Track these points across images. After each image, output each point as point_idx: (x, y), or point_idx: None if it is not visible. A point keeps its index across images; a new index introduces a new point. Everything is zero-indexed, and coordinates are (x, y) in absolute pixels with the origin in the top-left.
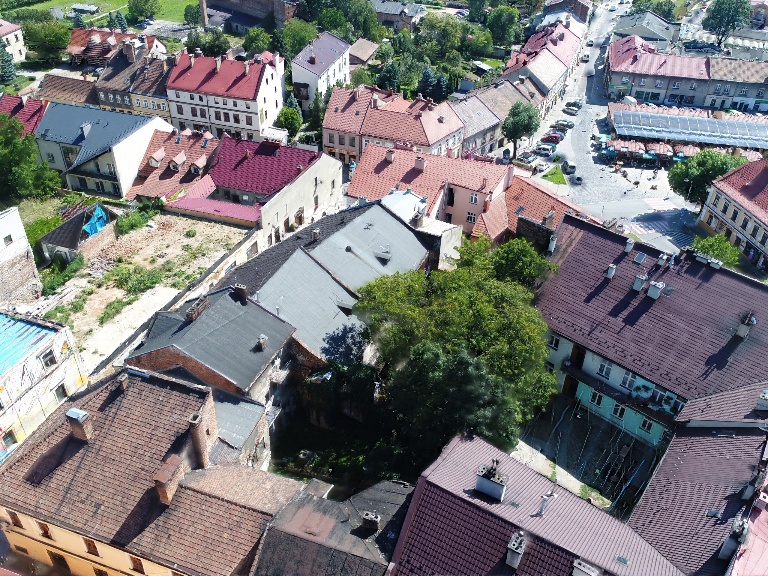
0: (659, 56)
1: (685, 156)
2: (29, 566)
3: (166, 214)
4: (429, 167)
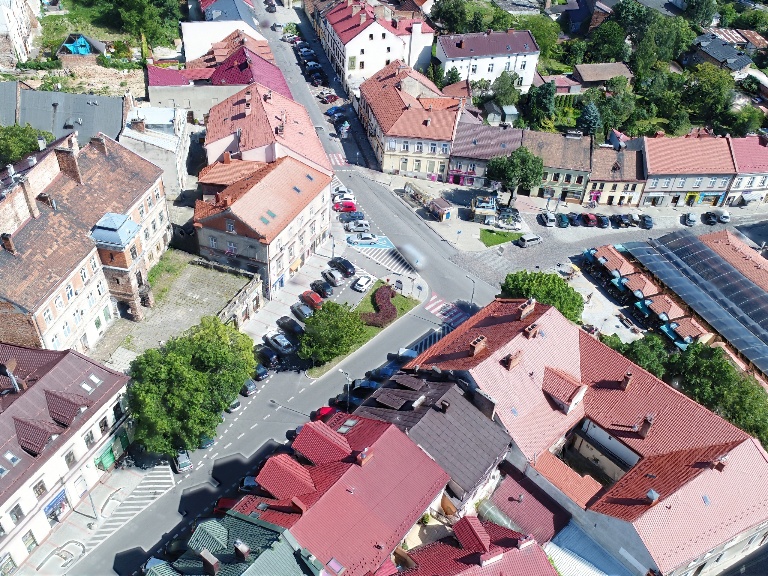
0: None
1: (649, 307)
2: None
3: (144, 71)
4: (252, 116)
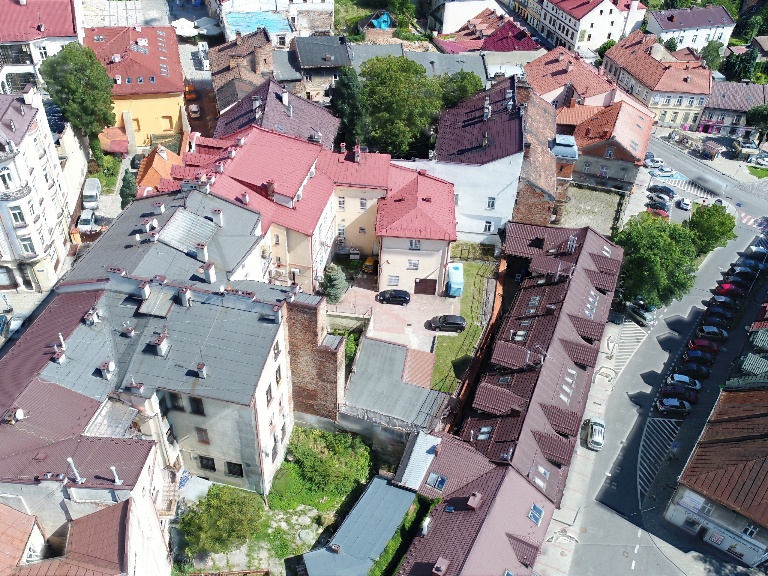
0: None
1: None
2: (211, 93)
3: (431, 43)
4: (574, 72)
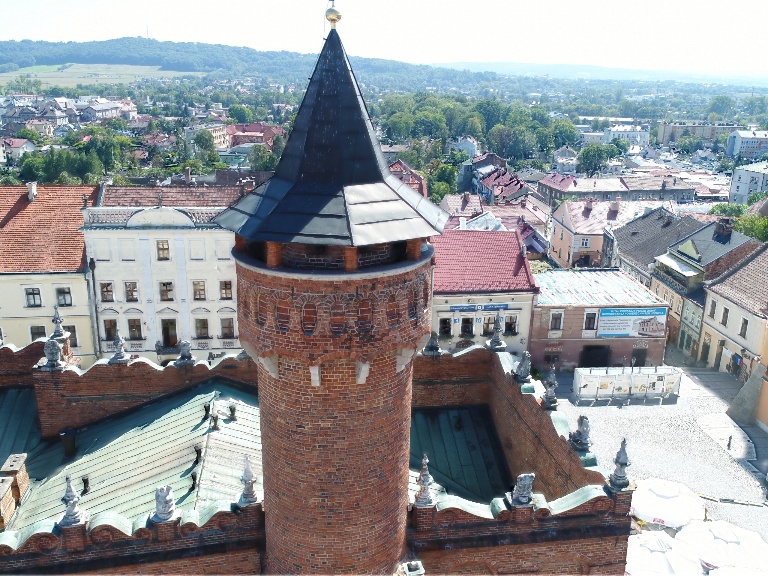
0: (590, 180)
1: None
2: None
3: None
4: (620, 209)
